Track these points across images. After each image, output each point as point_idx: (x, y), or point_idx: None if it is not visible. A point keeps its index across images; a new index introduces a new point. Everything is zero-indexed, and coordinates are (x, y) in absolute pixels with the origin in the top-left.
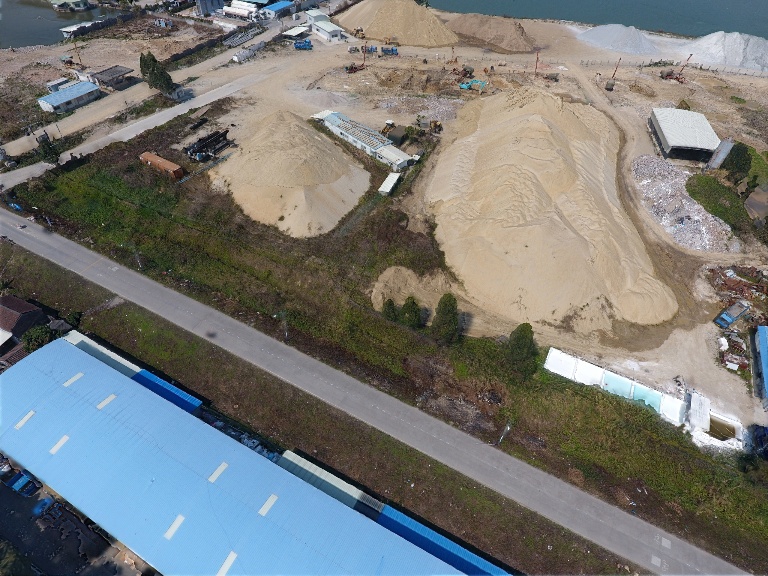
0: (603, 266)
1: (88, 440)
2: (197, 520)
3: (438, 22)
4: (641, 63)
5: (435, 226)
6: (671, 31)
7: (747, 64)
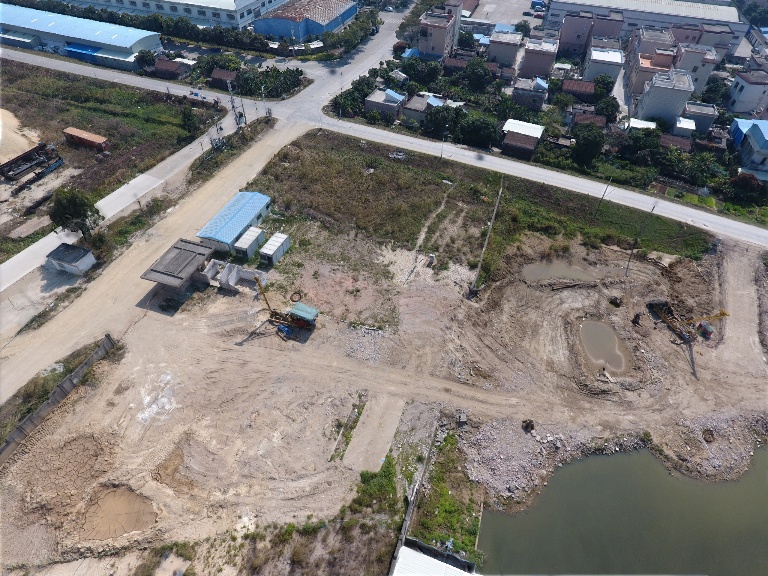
0: None
1: None
2: (61, 18)
3: None
4: None
5: None
6: None
7: None
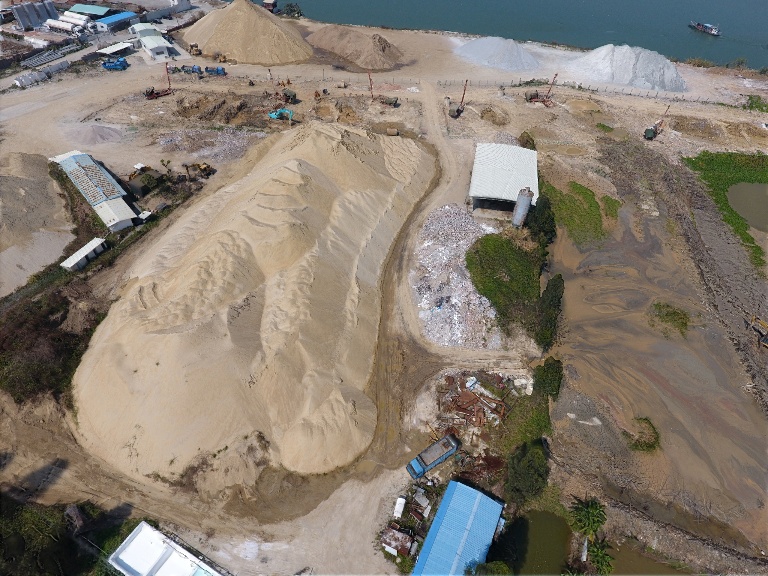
0: (269, 387)
1: None
2: None
3: (284, 36)
4: (512, 82)
5: (101, 318)
6: (565, 43)
7: (637, 82)
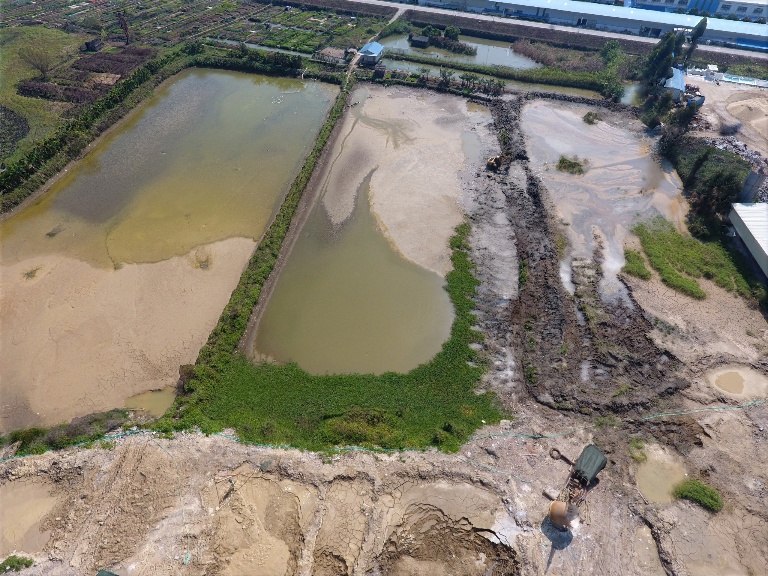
0: None
1: None
2: None
3: None
4: None
5: None
6: None
7: None
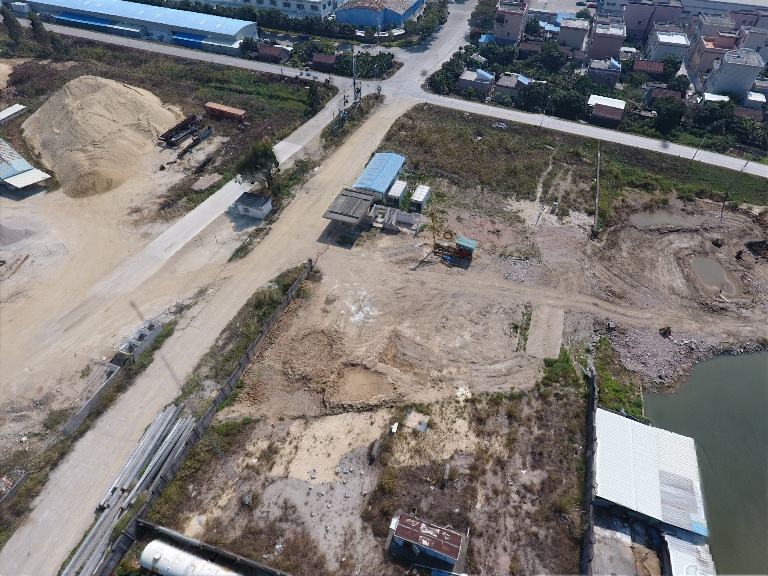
0: None
1: (205, 17)
2: (164, 10)
3: None
4: None
5: None
6: None
7: None
